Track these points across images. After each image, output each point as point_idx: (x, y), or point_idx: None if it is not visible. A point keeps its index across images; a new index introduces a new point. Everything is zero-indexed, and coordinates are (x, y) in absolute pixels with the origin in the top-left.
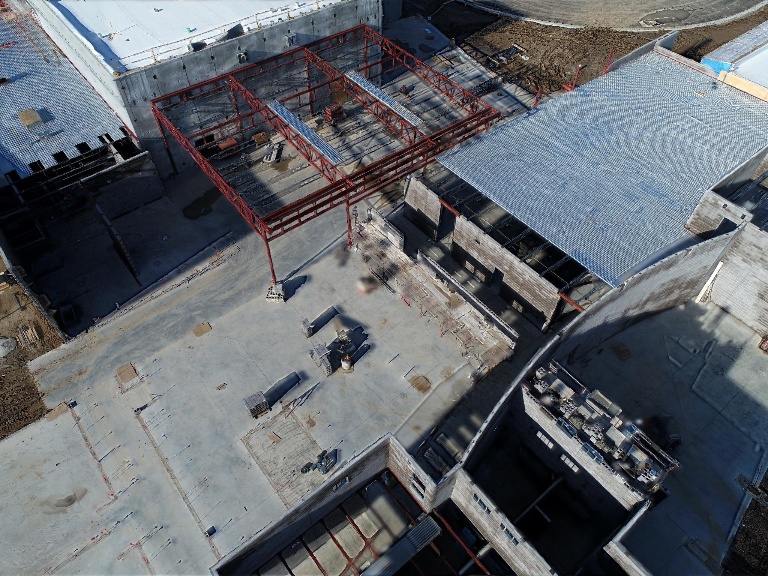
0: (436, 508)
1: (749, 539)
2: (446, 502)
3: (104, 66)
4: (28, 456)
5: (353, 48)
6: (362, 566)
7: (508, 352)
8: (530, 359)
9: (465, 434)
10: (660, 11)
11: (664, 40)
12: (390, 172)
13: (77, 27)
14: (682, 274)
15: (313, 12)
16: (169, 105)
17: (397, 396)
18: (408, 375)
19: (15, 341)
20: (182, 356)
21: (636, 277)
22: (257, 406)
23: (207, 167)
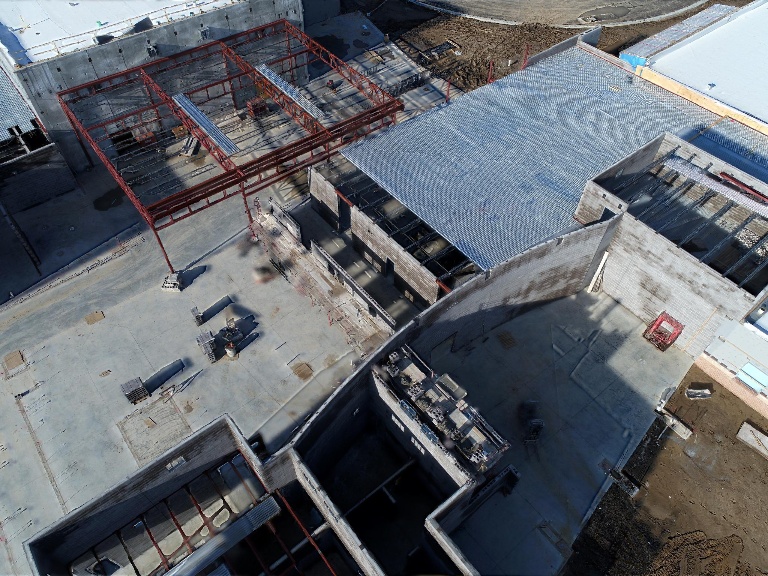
0: (280, 489)
1: (603, 522)
2: (296, 484)
3: (7, 58)
4: None
5: (274, 43)
6: (197, 544)
7: None
8: None
9: None
10: (600, 8)
11: (586, 35)
12: None
13: None
14: (562, 263)
15: (226, 6)
16: (74, 97)
17: (277, 383)
18: (292, 362)
19: None
20: (71, 344)
21: (502, 265)
22: (133, 392)
23: (103, 158)
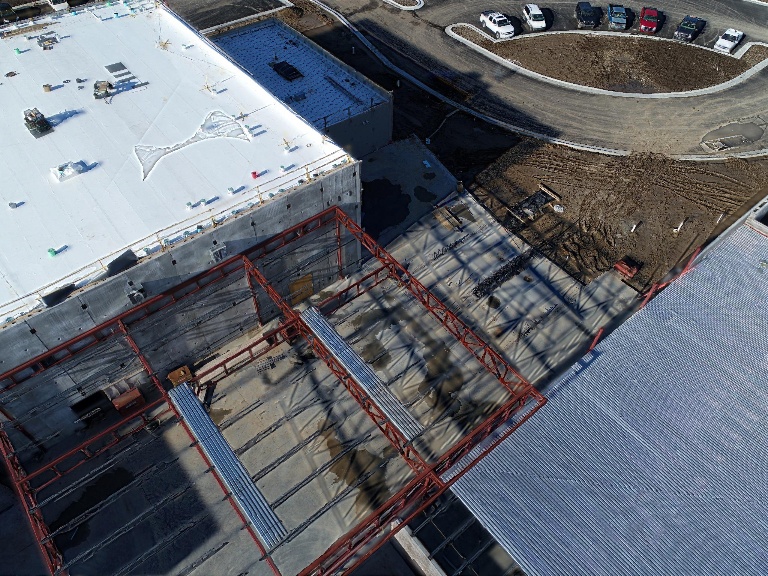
0: None
1: None
2: None
3: None
4: None
5: None
6: None
7: None
8: None
9: None
10: (724, 126)
11: (761, 211)
12: (371, 441)
13: None
14: None
15: (253, 210)
16: (6, 397)
17: None
18: None
19: None
20: None
21: None
22: None
23: None
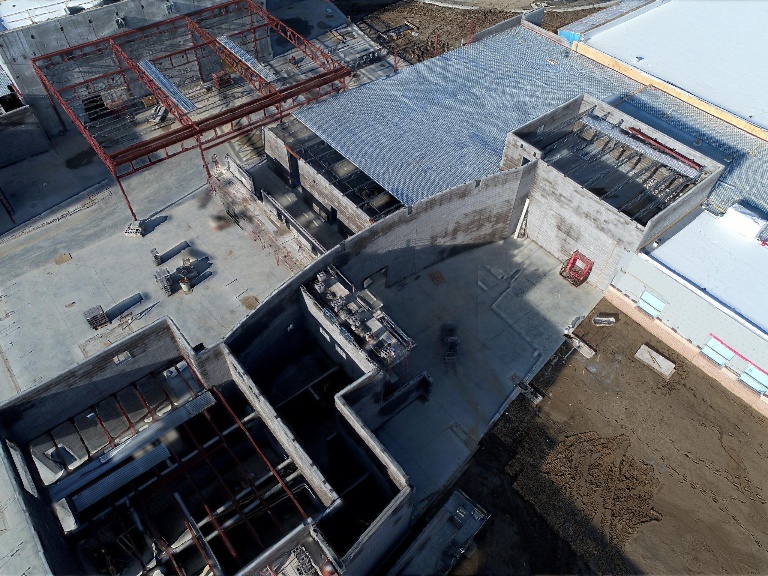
0: (217, 386)
1: (509, 424)
2: (233, 385)
3: None
4: None
5: None
6: (141, 428)
7: None
8: None
9: None
10: None
11: (529, 15)
12: None
13: None
14: (484, 206)
15: None
16: (47, 63)
17: (227, 312)
18: (240, 296)
19: None
20: (40, 280)
21: (423, 201)
22: (94, 317)
23: (72, 115)
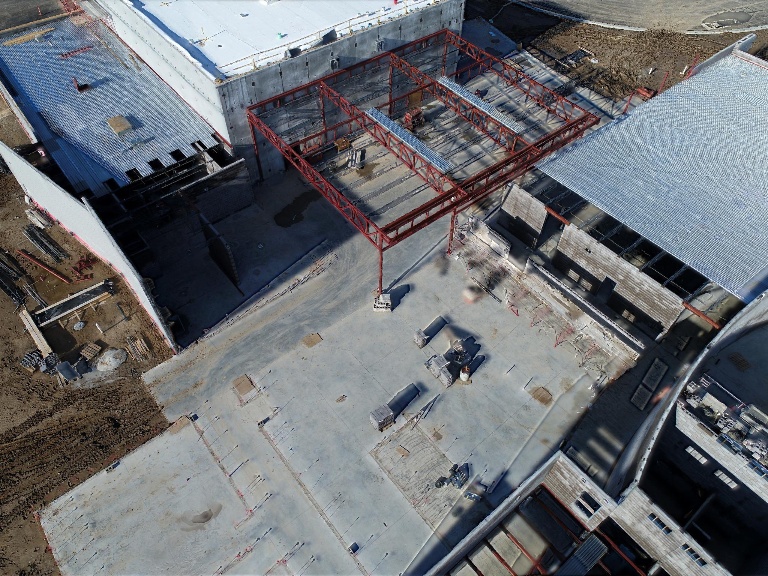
0: (597, 526)
1: None
2: None
3: (204, 73)
4: (157, 471)
5: (433, 53)
6: None
7: (631, 363)
8: (648, 370)
9: (594, 447)
10: (721, 13)
11: (743, 44)
12: None
13: (167, 33)
14: None
15: (402, 17)
16: (266, 112)
17: (520, 408)
18: (528, 386)
19: (125, 352)
20: (297, 367)
21: None
22: (385, 419)
23: None
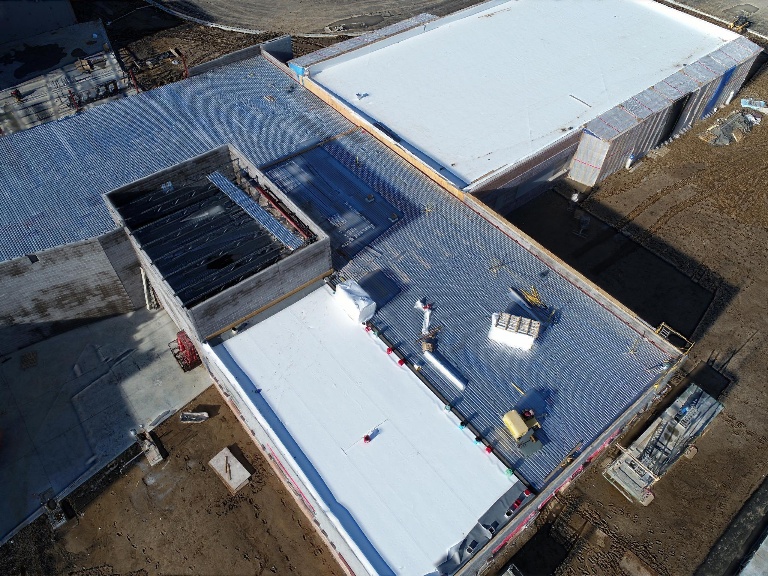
0: None
1: (7, 556)
2: None
3: None
4: None
5: None
6: None
7: None
8: None
9: None
10: (355, 17)
11: (269, 44)
12: None
13: None
14: (68, 280)
15: None
16: None
17: None
18: None
19: None
20: None
21: None
22: None
23: None
